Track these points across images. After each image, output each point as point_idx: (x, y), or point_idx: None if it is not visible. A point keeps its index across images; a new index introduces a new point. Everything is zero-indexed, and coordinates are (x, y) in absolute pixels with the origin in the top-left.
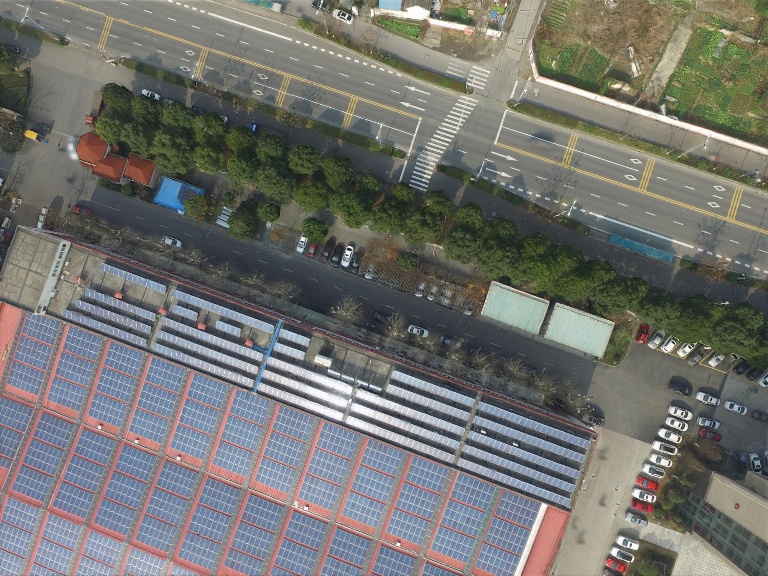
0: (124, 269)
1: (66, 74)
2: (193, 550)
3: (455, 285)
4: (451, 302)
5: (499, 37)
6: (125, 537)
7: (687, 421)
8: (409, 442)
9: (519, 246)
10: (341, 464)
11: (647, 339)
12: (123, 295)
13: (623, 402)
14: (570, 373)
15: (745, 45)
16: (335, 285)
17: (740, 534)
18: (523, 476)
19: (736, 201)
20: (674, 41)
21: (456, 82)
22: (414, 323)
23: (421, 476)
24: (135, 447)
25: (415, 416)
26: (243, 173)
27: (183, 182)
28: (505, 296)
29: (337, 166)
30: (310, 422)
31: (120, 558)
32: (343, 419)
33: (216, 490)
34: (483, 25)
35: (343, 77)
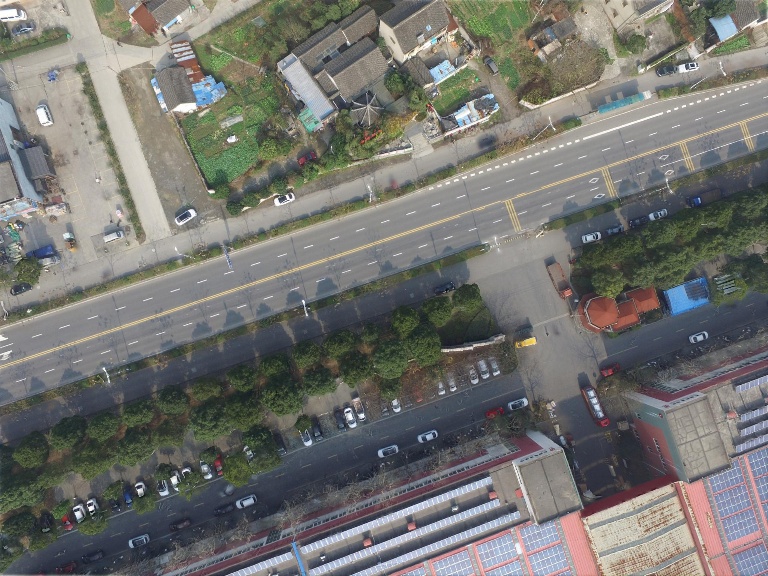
0: (753, 378)
1: (506, 273)
2: None
3: None
4: None
5: None
6: None
7: None
8: None
9: None
10: None
11: None
12: None
13: None
14: None
15: None
16: None
17: None
18: None
19: None
20: None
21: None
22: None
23: None
24: None
25: None
26: (756, 237)
27: (684, 283)
28: None
29: None
30: None
31: None
32: None
33: None
34: None
35: (722, 114)
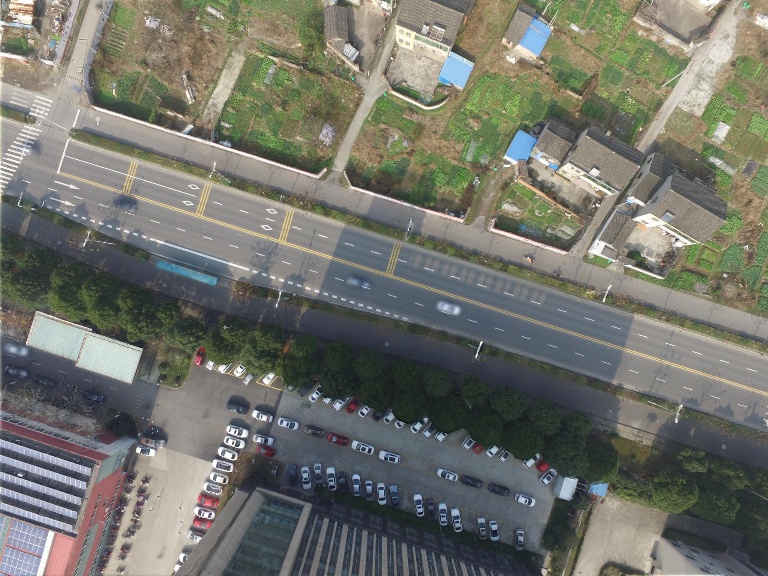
0: None
1: None
2: None
3: (10, 316)
4: (7, 333)
5: None
6: None
7: (244, 438)
8: None
9: None
10: None
11: (207, 360)
12: None
13: (185, 423)
14: (134, 397)
15: (293, 71)
16: None
17: None
18: (31, 505)
19: (287, 223)
20: (228, 68)
21: (15, 112)
22: None
23: None
24: None
25: None
26: None
27: None
28: (49, 326)
29: None
30: None
31: None
32: None
33: None
34: (44, 55)
35: None
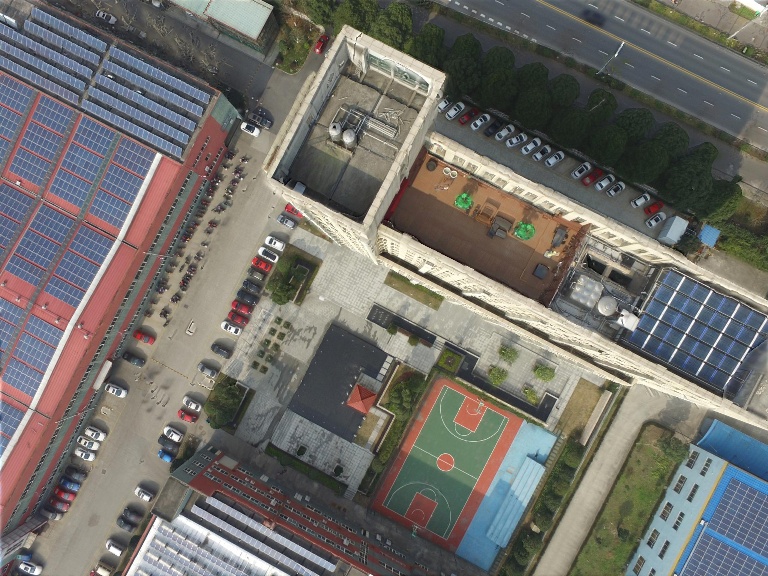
0: None
1: None
2: None
3: None
4: None
5: None
6: None
7: None
8: (37, 78)
9: None
10: None
11: (326, 51)
12: None
13: None
14: (247, 76)
15: None
16: None
17: None
18: (144, 125)
19: None
20: None
21: None
22: None
23: (47, 116)
24: None
25: (47, 54)
26: None
27: None
28: None
29: None
30: None
31: None
32: None
33: None
34: None
35: None
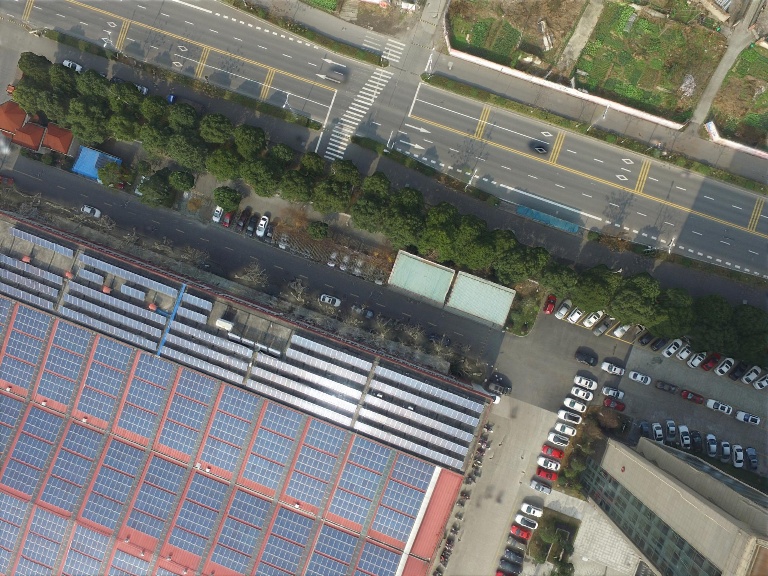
0: (33, 233)
1: None
2: (96, 510)
3: (365, 254)
4: (361, 271)
5: (414, 10)
6: (30, 497)
7: (592, 391)
8: (307, 405)
9: (424, 215)
10: (242, 427)
11: (555, 310)
12: (31, 259)
13: (530, 372)
14: (479, 343)
15: (655, 20)
16: (250, 255)
17: (623, 496)
18: (418, 439)
19: (644, 174)
20: (586, 15)
21: (371, 55)
22: (327, 292)
23: (319, 439)
24: (42, 409)
25: (313, 380)
26: (154, 141)
27: (101, 151)
28: (412, 265)
29: (245, 134)
30: (212, 385)
31: (25, 517)
32: (244, 382)
33: (120, 452)
34: None
35: (261, 49)
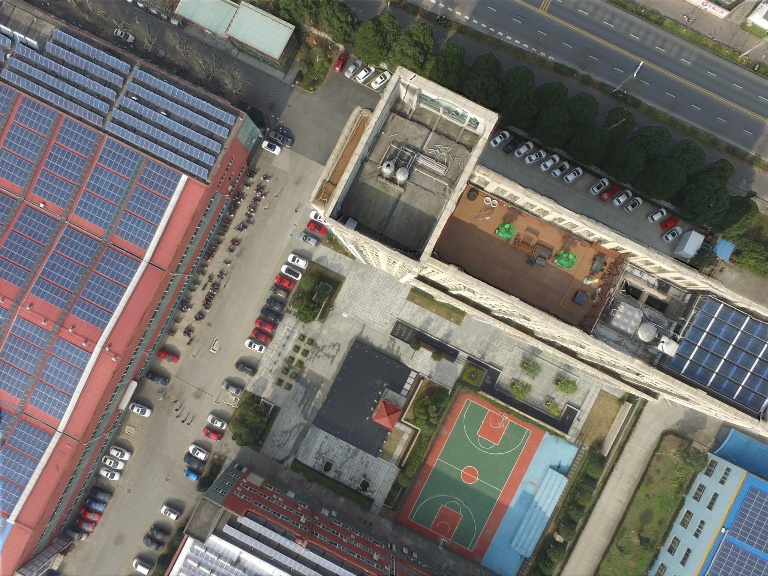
0: None
1: None
2: None
3: None
4: (154, 4)
5: None
6: None
7: None
8: (60, 100)
9: None
10: None
11: (345, 69)
12: None
13: (314, 128)
14: (267, 94)
15: None
16: None
17: None
18: (169, 147)
19: None
20: None
21: None
22: None
23: (70, 138)
24: None
25: (70, 76)
26: None
27: None
28: None
29: None
30: None
31: None
32: (1, 74)
33: None
34: None
35: None
